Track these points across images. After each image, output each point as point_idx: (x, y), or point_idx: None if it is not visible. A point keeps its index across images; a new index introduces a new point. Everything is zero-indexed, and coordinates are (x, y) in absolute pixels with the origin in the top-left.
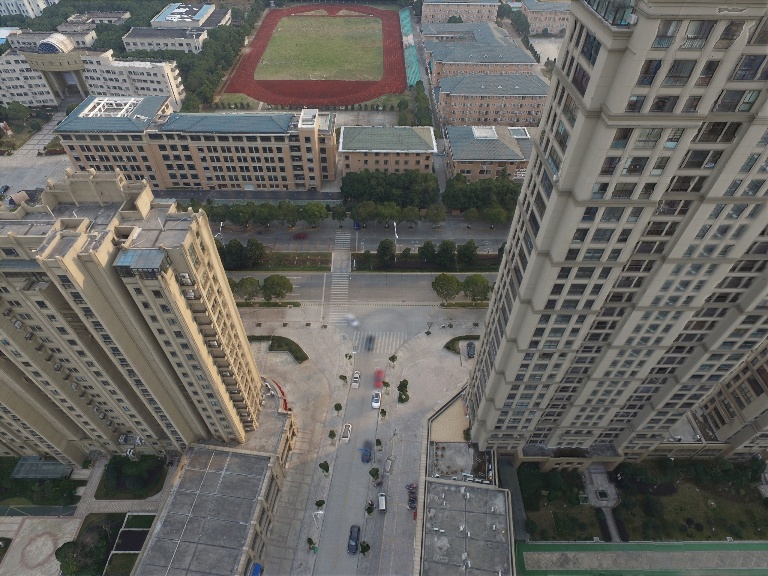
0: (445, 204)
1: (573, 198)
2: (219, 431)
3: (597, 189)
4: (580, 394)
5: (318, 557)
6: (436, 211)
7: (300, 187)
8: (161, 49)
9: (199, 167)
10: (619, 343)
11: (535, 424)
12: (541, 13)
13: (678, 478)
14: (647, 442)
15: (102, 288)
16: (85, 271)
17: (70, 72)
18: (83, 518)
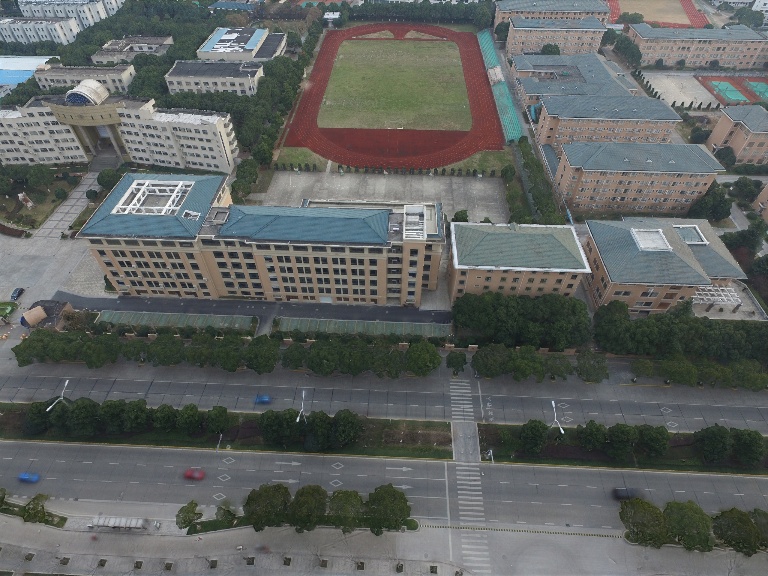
0: (600, 345)
1: None
2: None
3: None
4: None
5: None
6: (593, 361)
7: (392, 300)
8: (210, 90)
9: (264, 277)
10: None
11: None
12: (657, 41)
13: None
14: None
15: None
16: None
17: (103, 126)
18: None
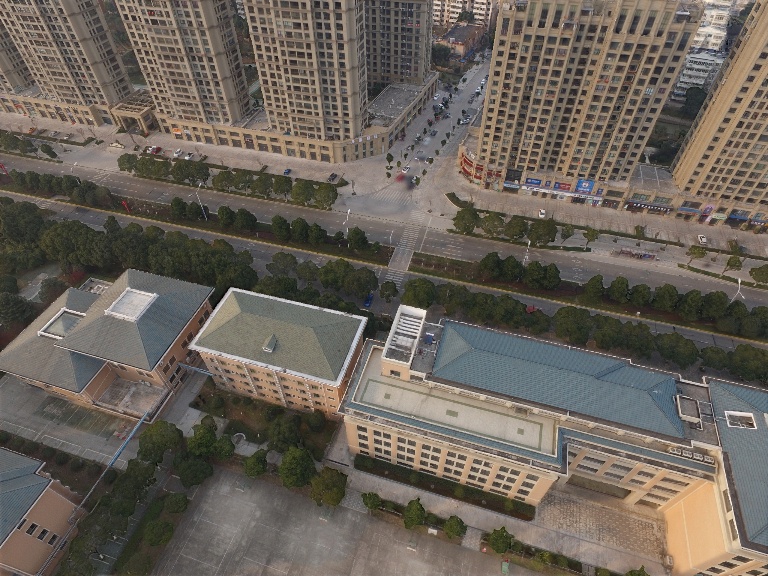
0: None
1: None
2: None
3: None
4: None
5: None
6: None
7: None
8: None
9: None
10: None
11: None
12: None
13: None
14: None
15: None
16: None
17: None
18: None
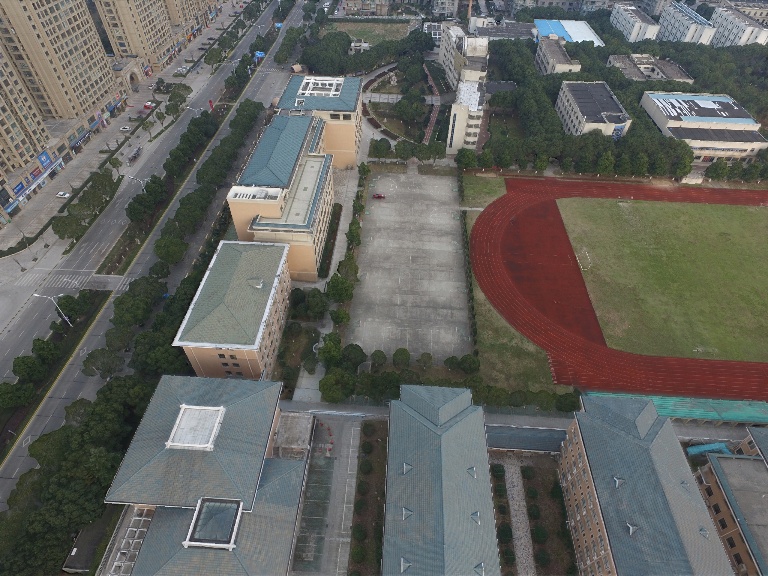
0: None
1: None
2: None
3: None
4: None
5: None
6: None
7: None
8: None
9: None
10: None
11: None
12: None
13: None
14: None
15: None
16: None
17: None
18: None
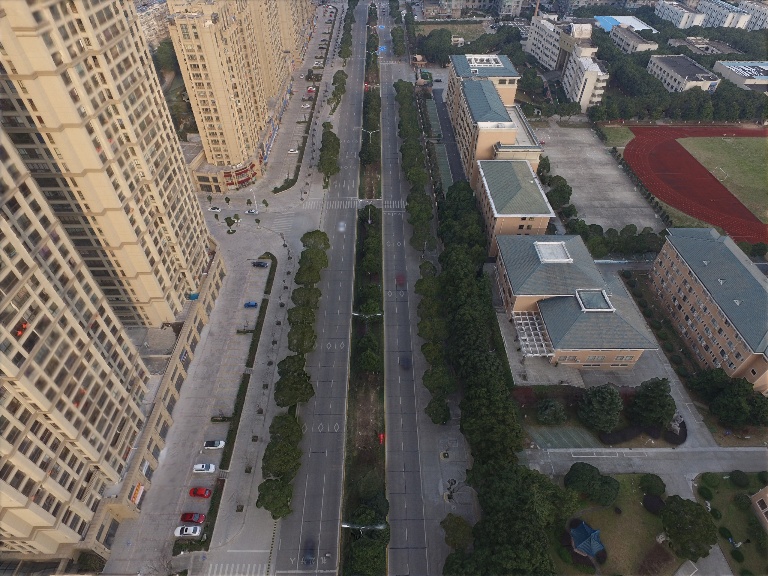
0: None
1: None
2: None
3: None
4: None
5: None
6: None
7: None
8: None
9: None
10: None
11: None
12: None
13: None
14: None
15: None
16: None
17: (567, 52)
18: None
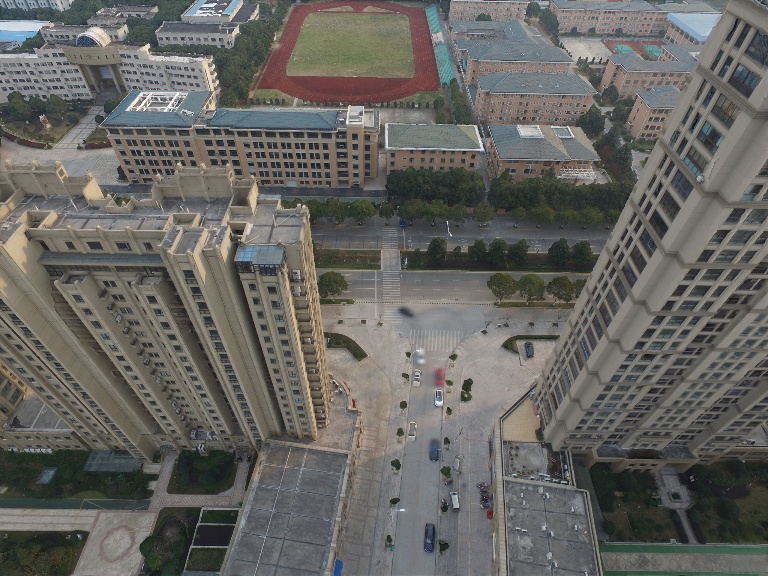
0: (491, 203)
1: (721, 199)
2: (294, 427)
3: (749, 191)
4: (669, 396)
5: (395, 555)
6: (484, 210)
7: (342, 184)
8: (194, 44)
9: (244, 163)
10: (724, 345)
11: (617, 425)
12: (571, 12)
13: (751, 481)
14: (724, 444)
15: (218, 283)
16: (207, 266)
17: (107, 66)
18: (158, 512)
